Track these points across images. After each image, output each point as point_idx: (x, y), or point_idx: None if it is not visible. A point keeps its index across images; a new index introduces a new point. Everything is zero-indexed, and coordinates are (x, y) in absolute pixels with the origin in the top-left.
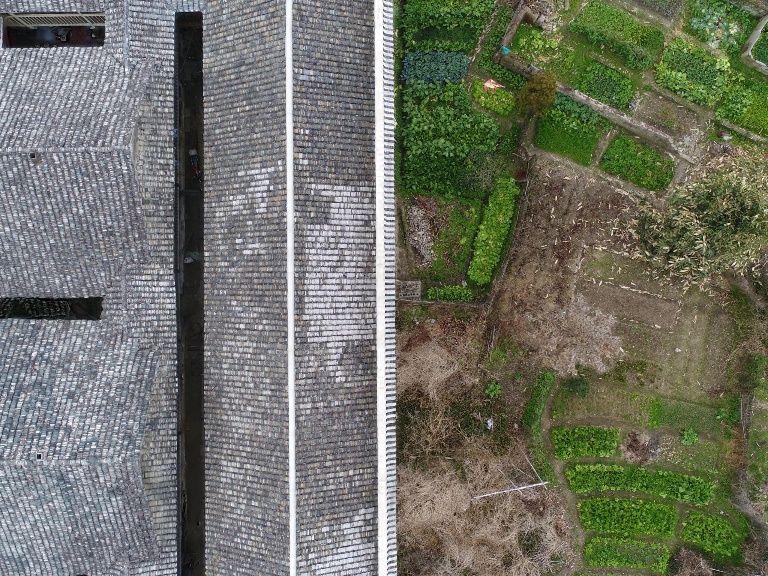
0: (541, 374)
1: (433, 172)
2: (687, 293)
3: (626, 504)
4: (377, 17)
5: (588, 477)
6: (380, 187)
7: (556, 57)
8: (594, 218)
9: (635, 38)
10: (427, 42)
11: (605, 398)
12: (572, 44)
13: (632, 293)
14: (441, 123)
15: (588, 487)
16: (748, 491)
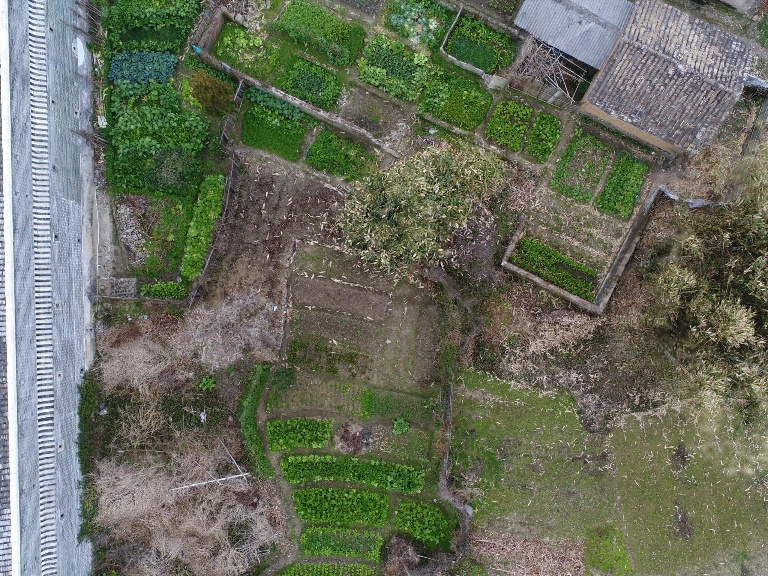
0: (255, 367)
1: (142, 170)
2: (397, 285)
3: (337, 494)
4: (1, 19)
5: (299, 468)
6: (6, 186)
7: (260, 55)
8: (304, 213)
9: (335, 35)
10: (132, 42)
11: (318, 390)
12: (277, 42)
13: (343, 286)
14: (148, 122)
15: (300, 478)
16: (454, 479)
